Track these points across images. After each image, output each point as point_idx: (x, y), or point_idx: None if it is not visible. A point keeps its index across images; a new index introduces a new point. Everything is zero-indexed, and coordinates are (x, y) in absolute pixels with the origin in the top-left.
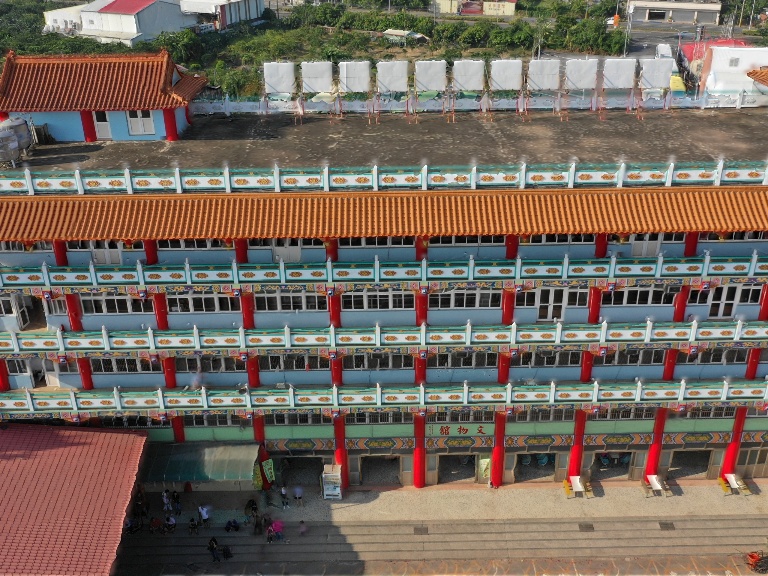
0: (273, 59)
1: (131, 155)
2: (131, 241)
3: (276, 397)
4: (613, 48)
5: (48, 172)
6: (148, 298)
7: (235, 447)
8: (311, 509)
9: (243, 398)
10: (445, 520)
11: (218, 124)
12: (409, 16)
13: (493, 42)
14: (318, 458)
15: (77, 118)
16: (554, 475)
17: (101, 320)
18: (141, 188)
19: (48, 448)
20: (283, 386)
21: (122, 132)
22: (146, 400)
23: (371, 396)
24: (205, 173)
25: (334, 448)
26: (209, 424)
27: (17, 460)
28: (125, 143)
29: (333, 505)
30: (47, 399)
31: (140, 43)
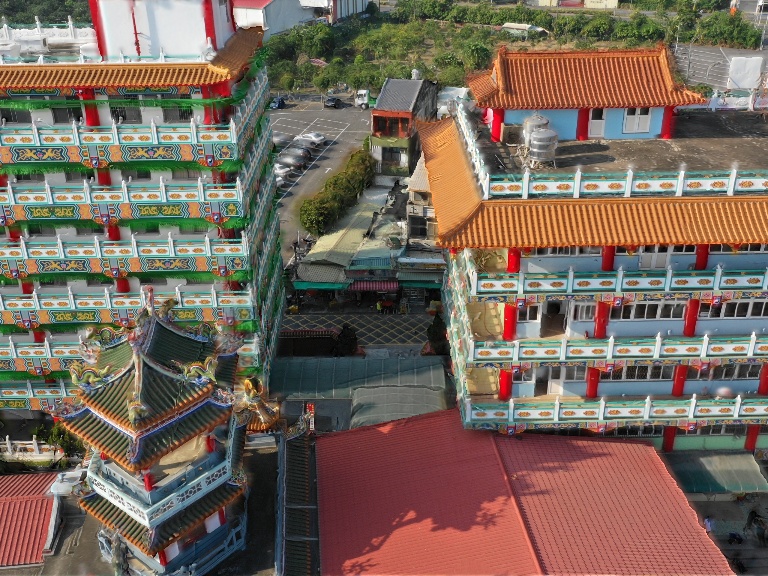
0: (406, 53)
1: (653, 154)
2: (739, 245)
3: None
4: (748, 41)
5: (598, 173)
6: (681, 303)
7: (730, 457)
8: None
9: None
10: None
11: (681, 121)
12: (526, 9)
13: (618, 35)
14: None
15: (574, 116)
16: None
17: (627, 326)
18: (743, 189)
19: (576, 459)
20: None
21: (616, 130)
22: (676, 409)
23: None
24: (766, 173)
25: None
26: (702, 433)
27: (560, 472)
28: (622, 142)
29: None
30: (574, 408)
31: (275, 38)
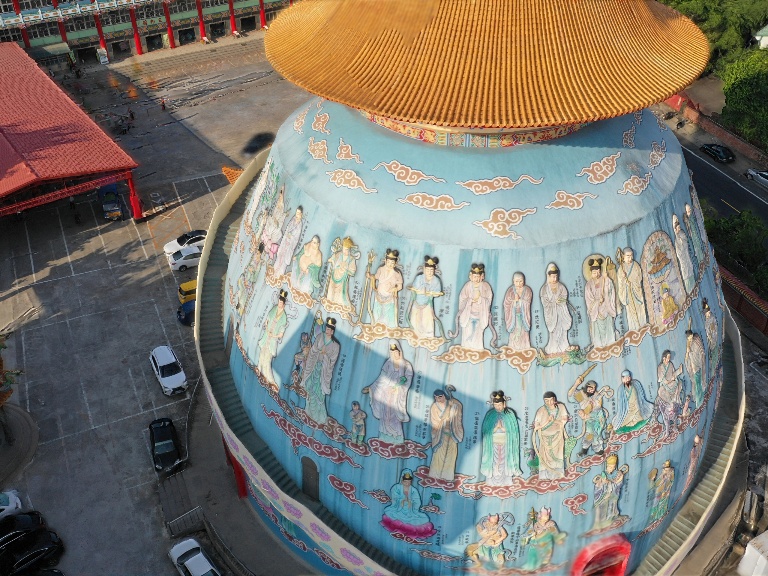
0: None
1: None
2: None
3: (72, 9)
4: None
5: None
6: None
7: (56, 44)
8: (98, 68)
9: (58, 12)
10: (157, 59)
11: None
12: None
13: None
14: (93, 48)
15: None
16: (196, 40)
17: None
18: None
19: None
20: (74, 3)
21: None
22: (15, 20)
23: (112, 3)
24: None
25: (100, 40)
26: (41, 36)
27: None
28: None
29: (107, 65)
30: None
31: None
